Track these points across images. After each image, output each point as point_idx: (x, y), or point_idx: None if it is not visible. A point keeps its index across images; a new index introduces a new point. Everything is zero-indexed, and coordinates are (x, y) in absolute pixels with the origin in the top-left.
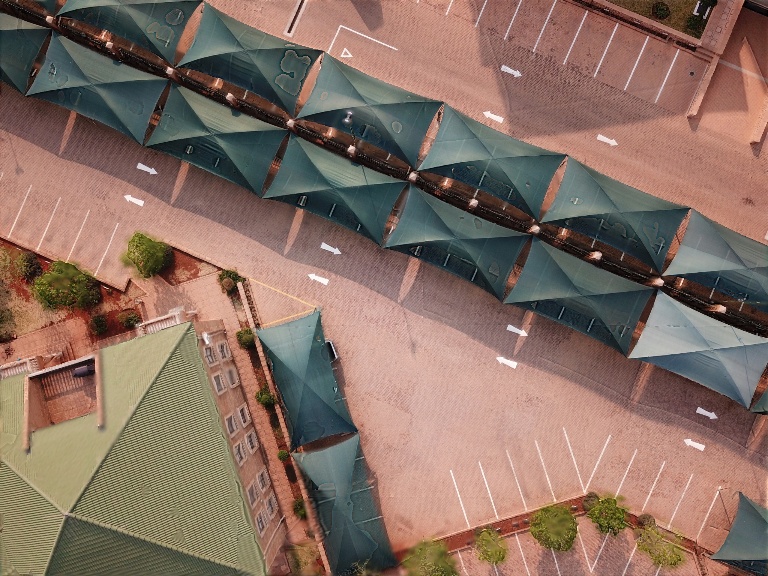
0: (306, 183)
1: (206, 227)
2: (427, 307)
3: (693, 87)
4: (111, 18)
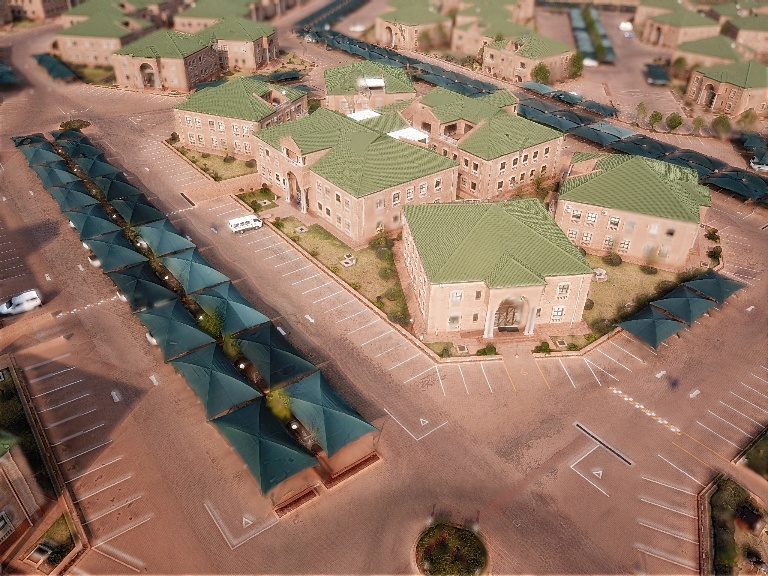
0: None
1: None
2: None
3: None
4: None
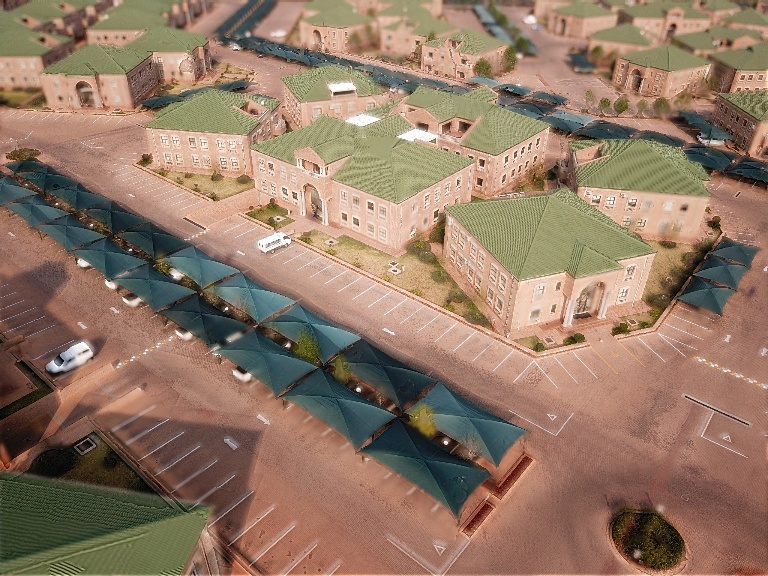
0: None
1: None
2: None
3: None
4: None
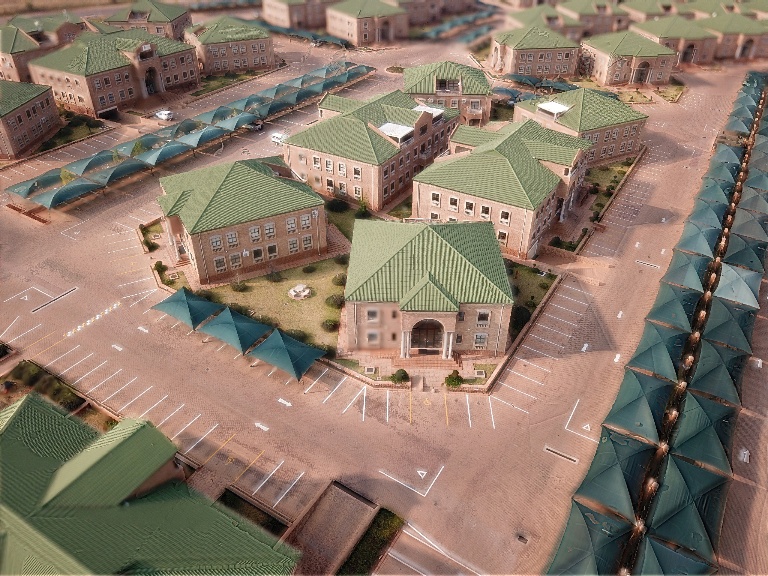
0: (712, 442)
1: (767, 548)
2: (766, 406)
3: (582, 282)
4: (606, 567)
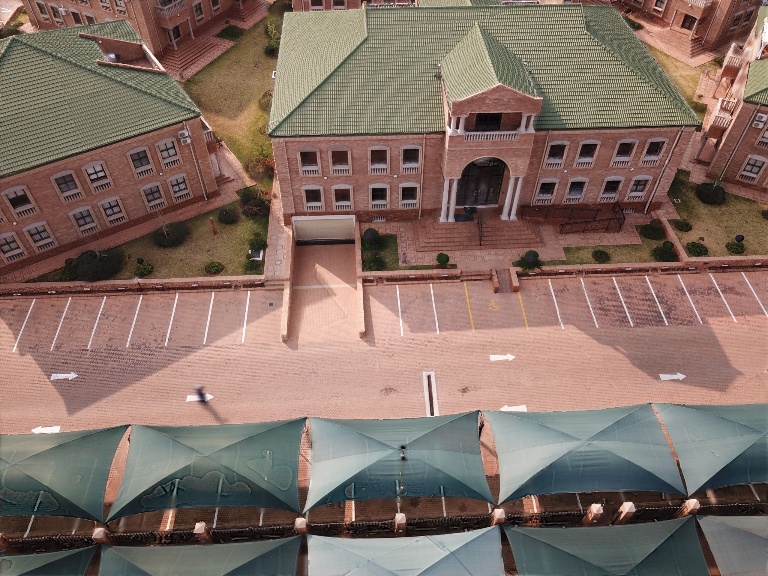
0: None
1: None
2: None
3: (277, 315)
4: None
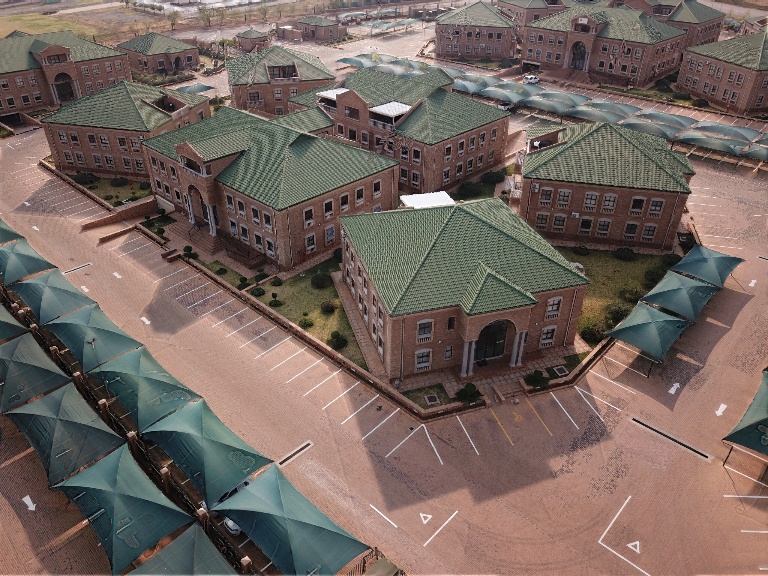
0: None
1: None
2: None
3: None
4: None
